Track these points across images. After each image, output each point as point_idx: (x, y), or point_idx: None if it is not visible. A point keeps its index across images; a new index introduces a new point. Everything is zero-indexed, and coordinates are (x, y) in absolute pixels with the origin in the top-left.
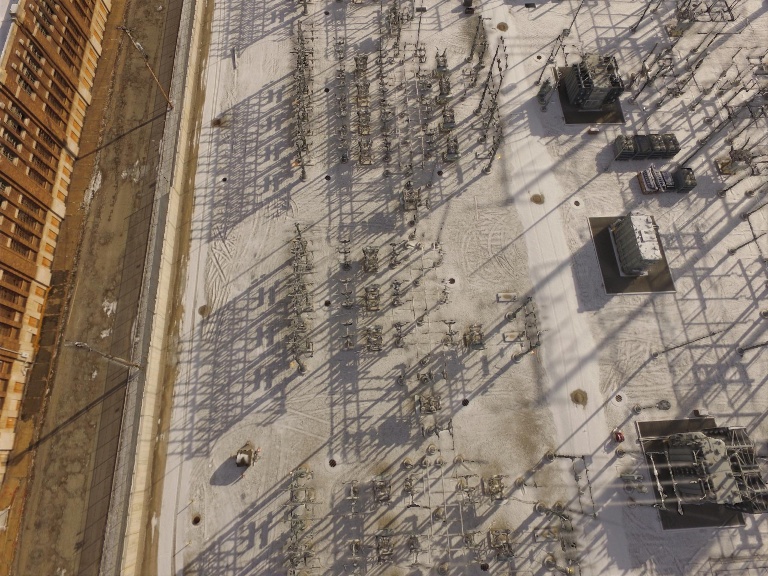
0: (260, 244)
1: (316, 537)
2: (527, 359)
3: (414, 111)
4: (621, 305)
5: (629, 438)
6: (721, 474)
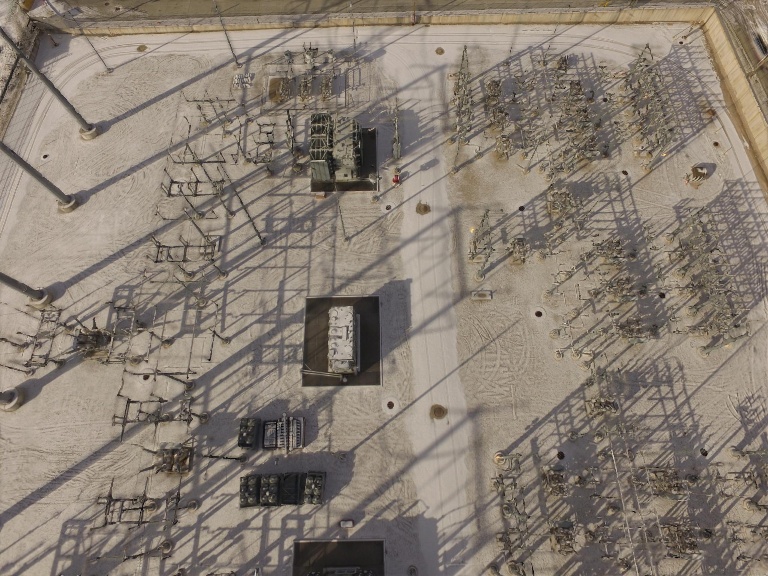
0: (755, 363)
1: (627, 132)
2: (466, 240)
3: (609, 573)
4: (367, 285)
5: (387, 181)
6: (344, 133)
